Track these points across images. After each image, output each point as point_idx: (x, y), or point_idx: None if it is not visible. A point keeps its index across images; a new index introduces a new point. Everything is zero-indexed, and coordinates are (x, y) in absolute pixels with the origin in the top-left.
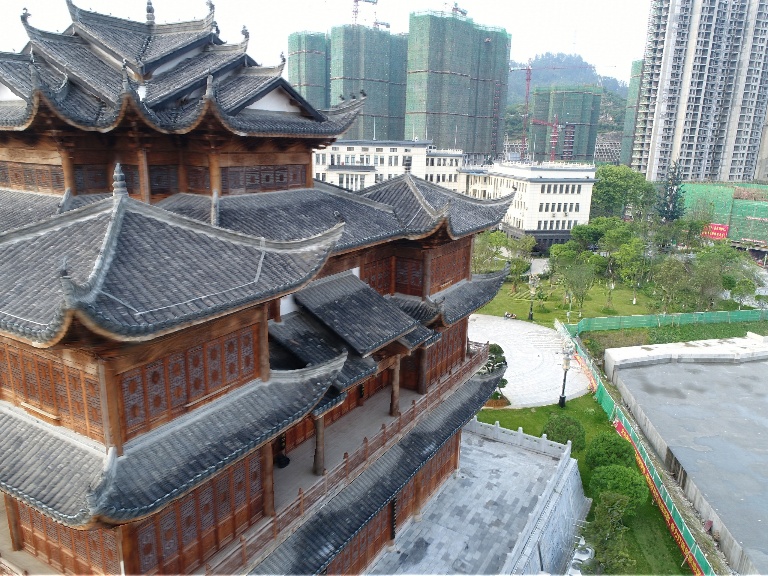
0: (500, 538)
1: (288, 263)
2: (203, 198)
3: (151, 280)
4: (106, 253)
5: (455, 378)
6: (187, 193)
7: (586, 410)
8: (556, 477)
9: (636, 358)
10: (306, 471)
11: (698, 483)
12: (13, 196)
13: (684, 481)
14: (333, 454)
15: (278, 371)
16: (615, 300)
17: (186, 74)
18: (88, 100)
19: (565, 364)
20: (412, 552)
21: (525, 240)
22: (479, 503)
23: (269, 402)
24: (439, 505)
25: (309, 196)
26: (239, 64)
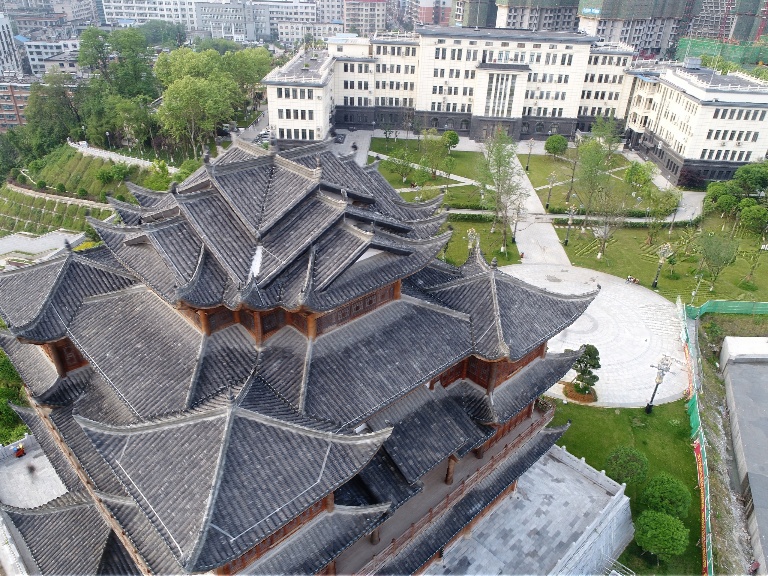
0: (531, 570)
1: (347, 453)
2: (302, 339)
3: (245, 497)
4: (217, 480)
5: (511, 447)
6: (291, 326)
7: (671, 421)
8: (599, 520)
9: (756, 354)
10: (366, 538)
11: (761, 522)
12: (169, 316)
13: (750, 513)
14: (390, 522)
15: (340, 506)
16: (762, 268)
17: (294, 236)
18: (218, 266)
19: (658, 378)
20: (455, 569)
21: (671, 192)
22: (524, 529)
23: (330, 532)
24: (489, 524)
25: (393, 314)
26: (338, 222)
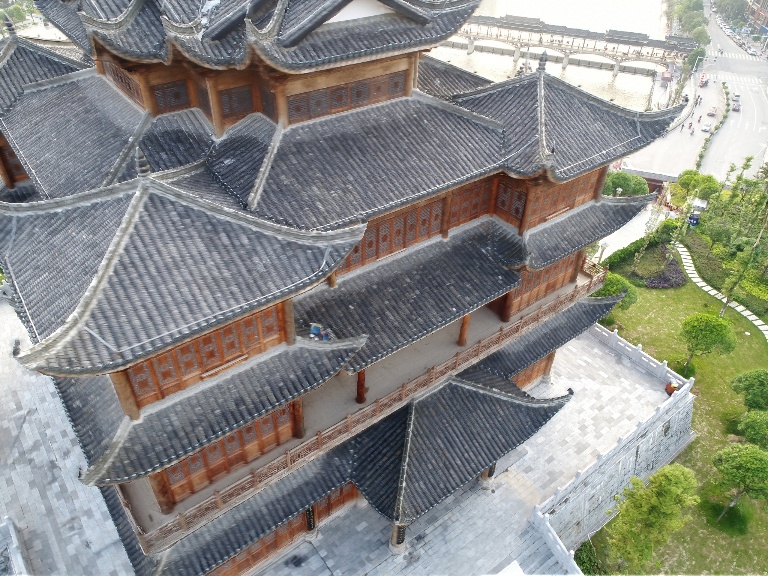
0: None
1: None
2: None
3: None
4: None
5: None
6: None
7: None
8: None
9: None
10: None
11: None
12: None
13: None
14: None
15: None
16: None
17: None
18: None
19: None
20: None
21: None
22: None
23: None
24: None
25: (124, 119)
26: None
